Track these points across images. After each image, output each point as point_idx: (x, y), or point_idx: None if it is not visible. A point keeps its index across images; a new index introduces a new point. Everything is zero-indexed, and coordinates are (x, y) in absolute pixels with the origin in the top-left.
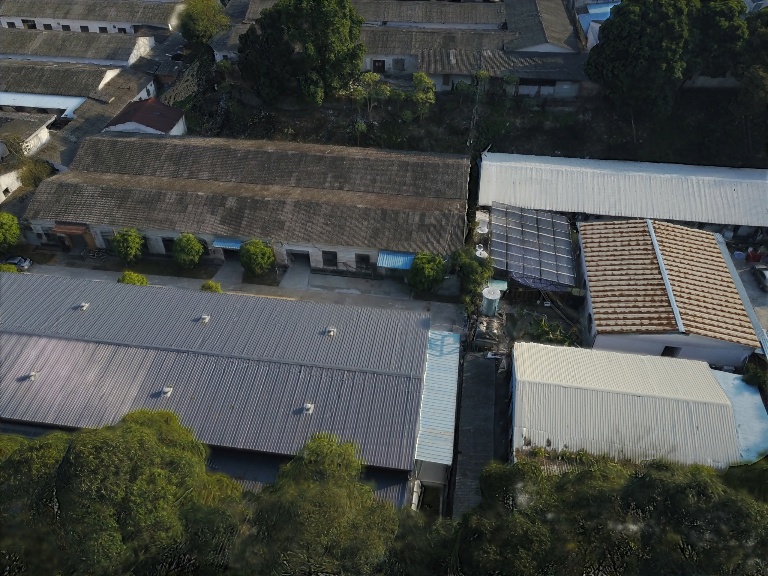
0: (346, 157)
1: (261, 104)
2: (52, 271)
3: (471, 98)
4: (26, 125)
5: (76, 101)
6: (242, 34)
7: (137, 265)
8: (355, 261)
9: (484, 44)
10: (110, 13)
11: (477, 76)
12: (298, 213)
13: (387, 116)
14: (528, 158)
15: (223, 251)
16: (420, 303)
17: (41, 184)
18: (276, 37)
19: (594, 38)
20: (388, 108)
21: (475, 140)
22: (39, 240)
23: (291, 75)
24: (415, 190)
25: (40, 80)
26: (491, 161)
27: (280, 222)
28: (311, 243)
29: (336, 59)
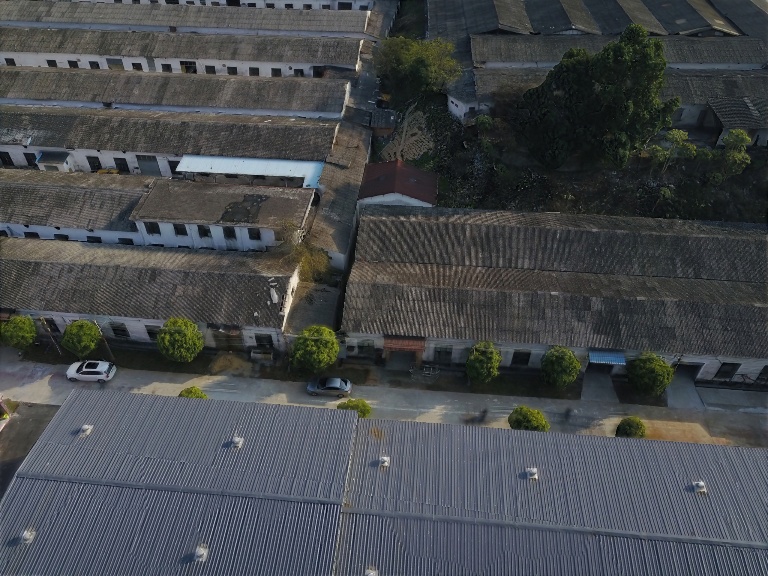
0: (689, 236)
1: (528, 165)
2: (379, 394)
3: None
4: (289, 205)
5: (310, 166)
6: (532, 89)
7: None
8: (759, 373)
9: None
10: (285, 53)
11: None
12: (686, 317)
13: (685, 177)
14: None
15: (588, 363)
16: None
17: (349, 285)
18: (586, 94)
19: None
20: (682, 168)
21: None
22: (346, 353)
23: (592, 136)
24: None
25: (258, 141)
26: None
27: (668, 329)
28: (715, 355)
29: (650, 117)
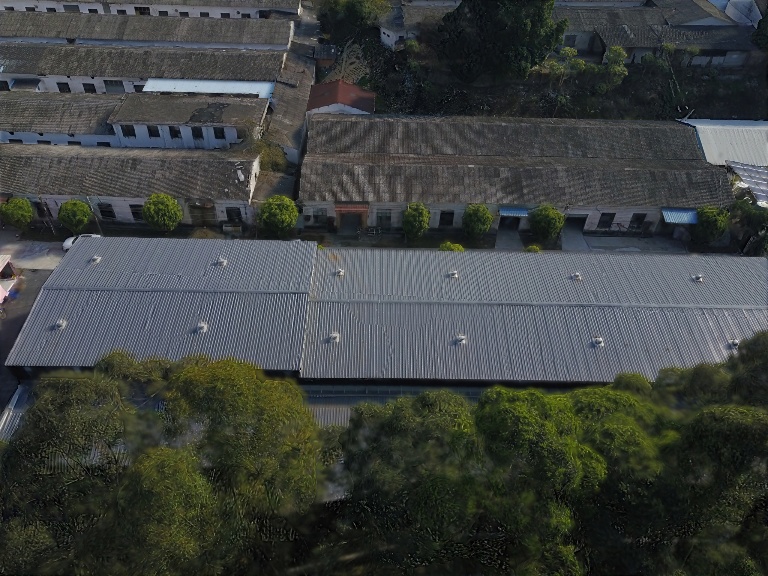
0: (578, 127)
1: (450, 82)
2: None
3: (652, 70)
4: (248, 109)
5: (263, 86)
6: (449, 12)
7: (417, 240)
8: (630, 221)
9: (647, 19)
10: None
11: (665, 48)
12: (573, 179)
13: (578, 89)
14: (724, 122)
15: (500, 220)
16: (698, 255)
17: (304, 166)
18: (493, 14)
19: (741, 12)
20: (576, 82)
21: (661, 109)
22: (304, 223)
23: (500, 51)
24: (654, 154)
25: (215, 66)
26: (701, 125)
27: (560, 188)
28: (595, 206)
29: (545, 35)
